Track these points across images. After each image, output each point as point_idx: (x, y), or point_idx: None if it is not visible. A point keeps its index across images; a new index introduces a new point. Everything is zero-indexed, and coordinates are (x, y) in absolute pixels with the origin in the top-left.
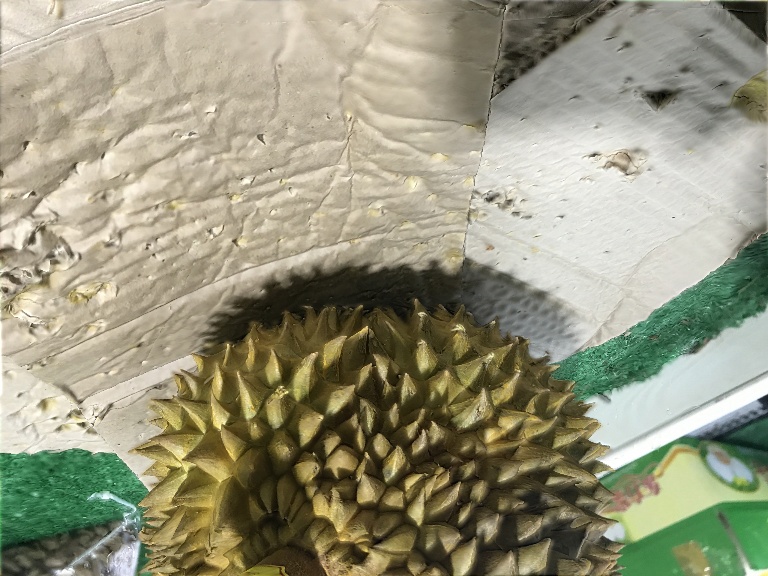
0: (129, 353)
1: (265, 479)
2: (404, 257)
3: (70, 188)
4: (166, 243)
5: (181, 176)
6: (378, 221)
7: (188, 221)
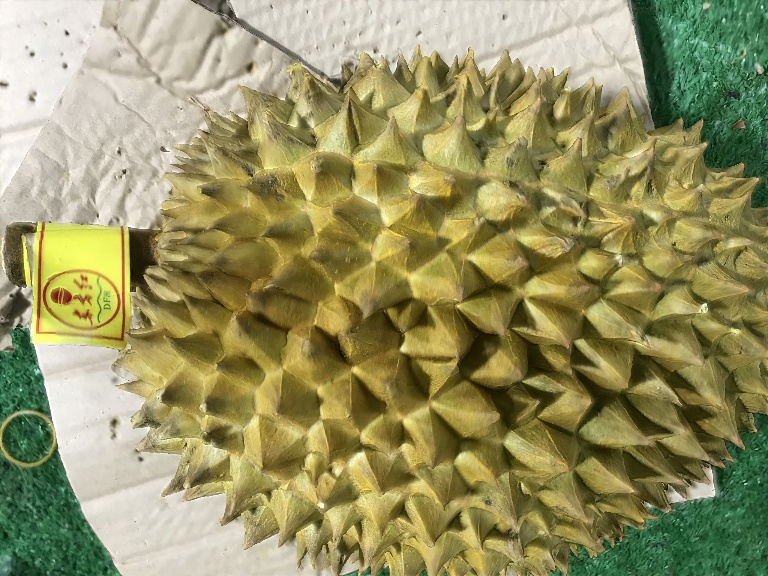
0: None
1: None
2: None
3: None
4: None
5: (145, 202)
6: None
7: None
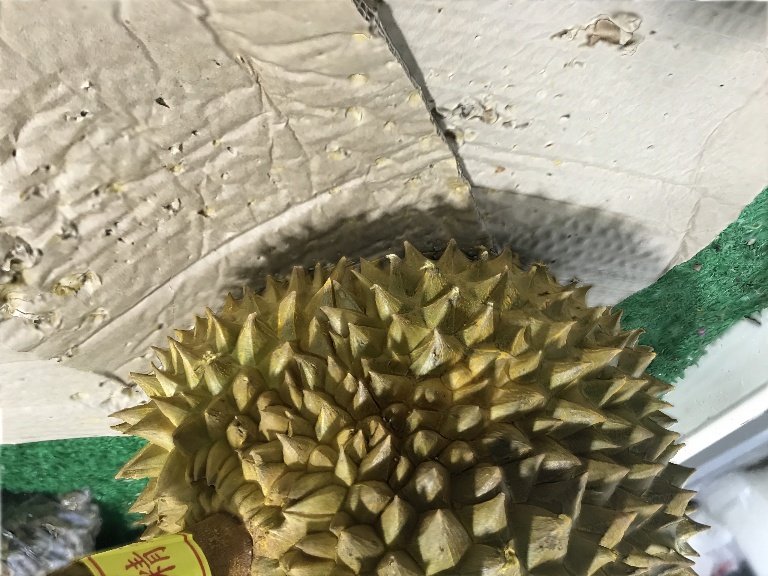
0: (154, 336)
1: (201, 446)
2: (401, 198)
3: None
4: (127, 226)
5: (101, 158)
6: (345, 164)
7: (139, 201)
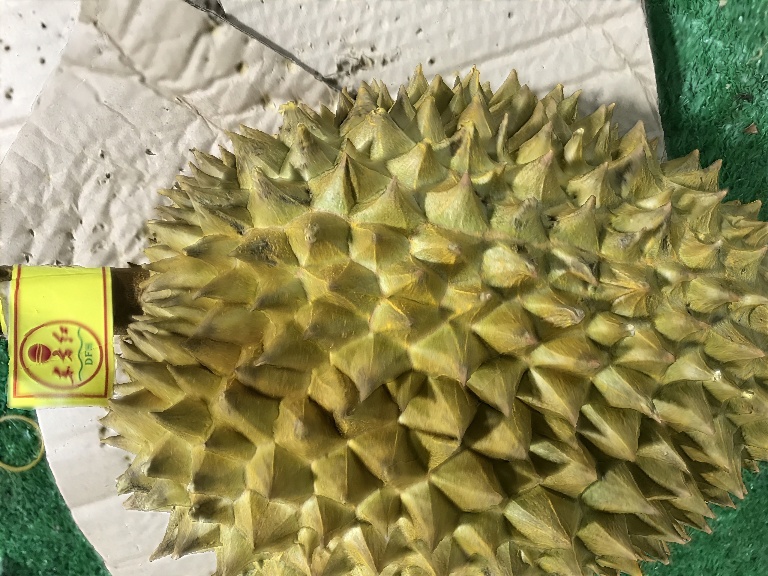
0: None
1: None
2: None
3: (79, 252)
4: None
5: (130, 208)
6: None
7: None
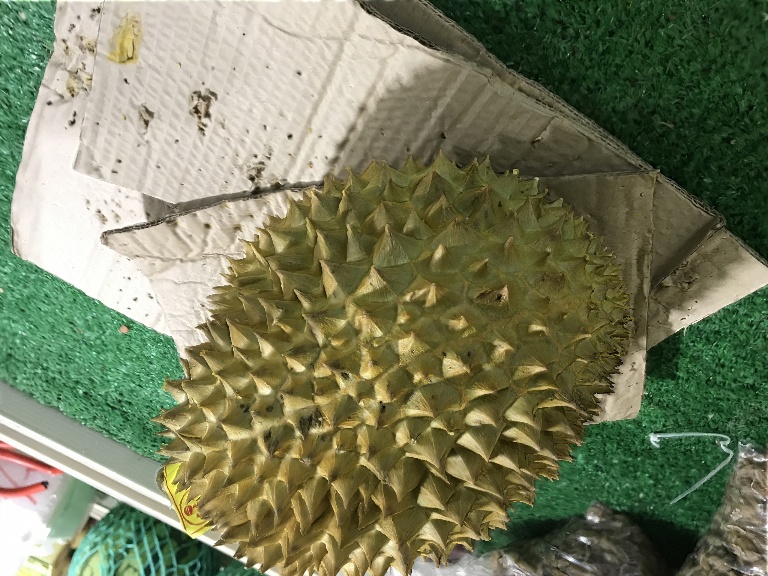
0: None
1: None
2: None
3: None
4: None
5: None
6: None
7: None
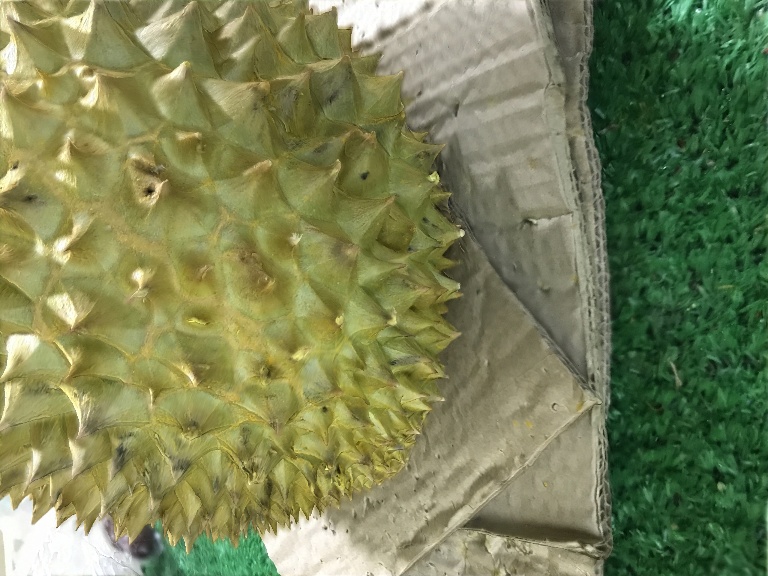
0: None
1: None
2: None
3: None
4: None
5: None
6: None
7: None
